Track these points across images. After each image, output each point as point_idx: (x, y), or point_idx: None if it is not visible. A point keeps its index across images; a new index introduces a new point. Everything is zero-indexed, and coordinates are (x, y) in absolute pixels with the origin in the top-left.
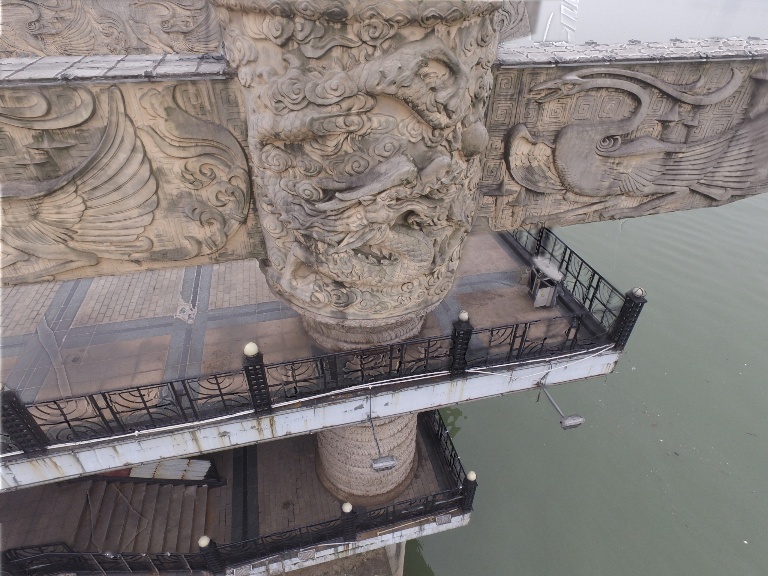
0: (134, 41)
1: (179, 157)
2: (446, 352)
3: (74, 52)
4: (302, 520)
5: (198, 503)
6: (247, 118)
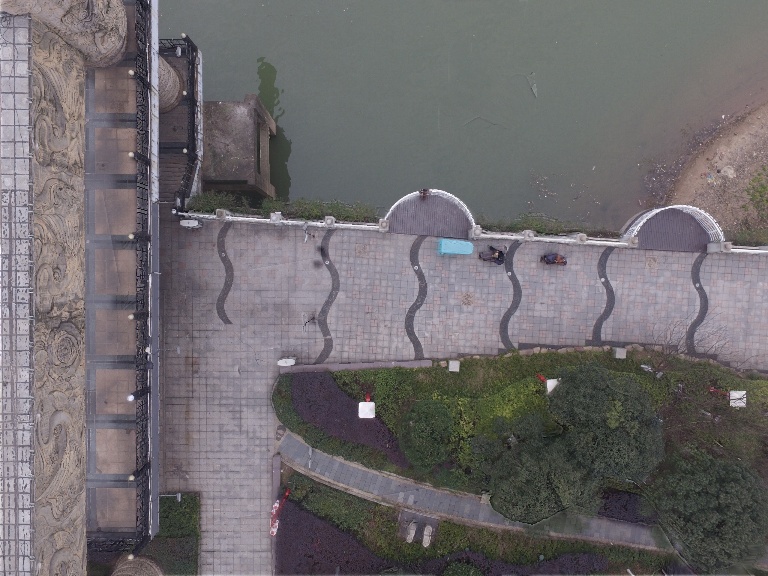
0: None
1: (53, 57)
2: (141, 7)
3: None
4: (183, 123)
5: (165, 167)
6: (45, 21)
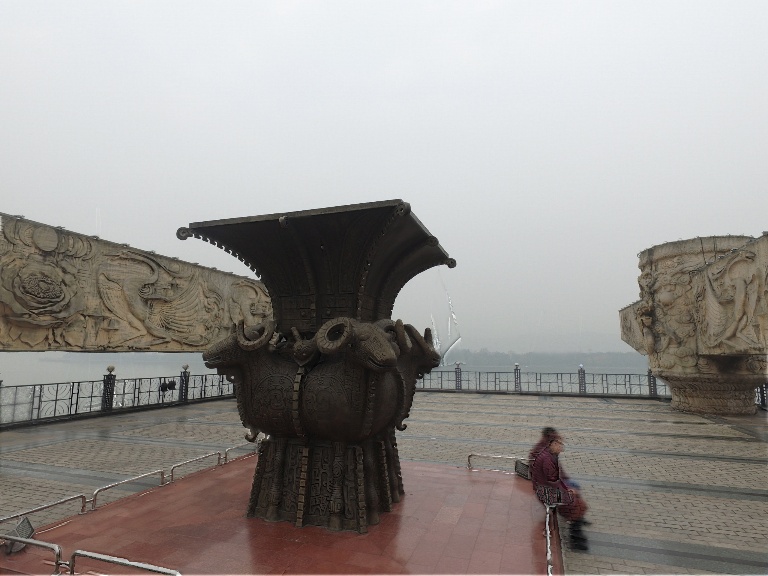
0: (226, 320)
1: None
2: None
3: (174, 326)
4: None
5: None
6: None
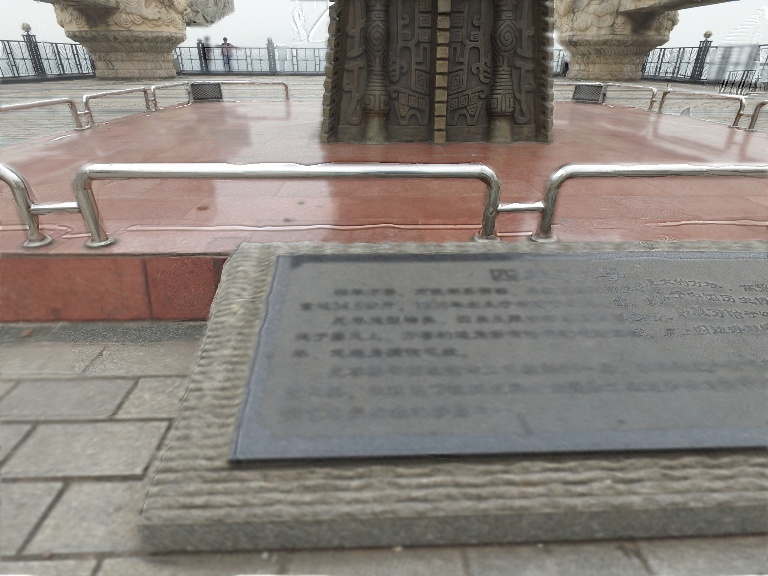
0: None
1: None
2: None
3: None
4: None
5: None
6: None
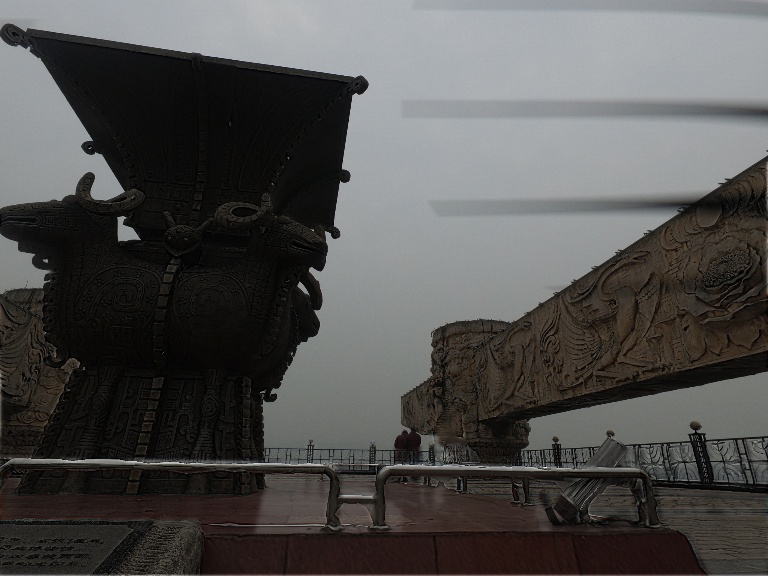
0: None
1: None
2: None
3: None
4: None
5: None
6: None
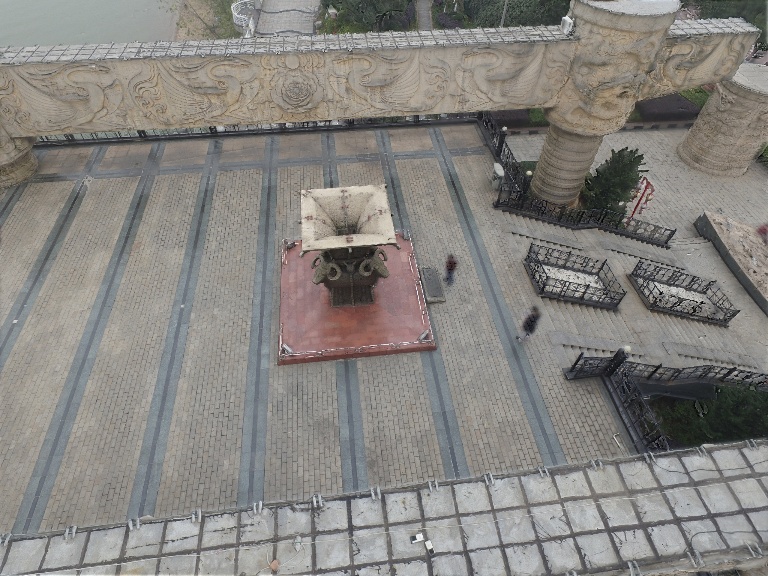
0: None
1: None
2: None
3: None
4: None
5: None
6: None
